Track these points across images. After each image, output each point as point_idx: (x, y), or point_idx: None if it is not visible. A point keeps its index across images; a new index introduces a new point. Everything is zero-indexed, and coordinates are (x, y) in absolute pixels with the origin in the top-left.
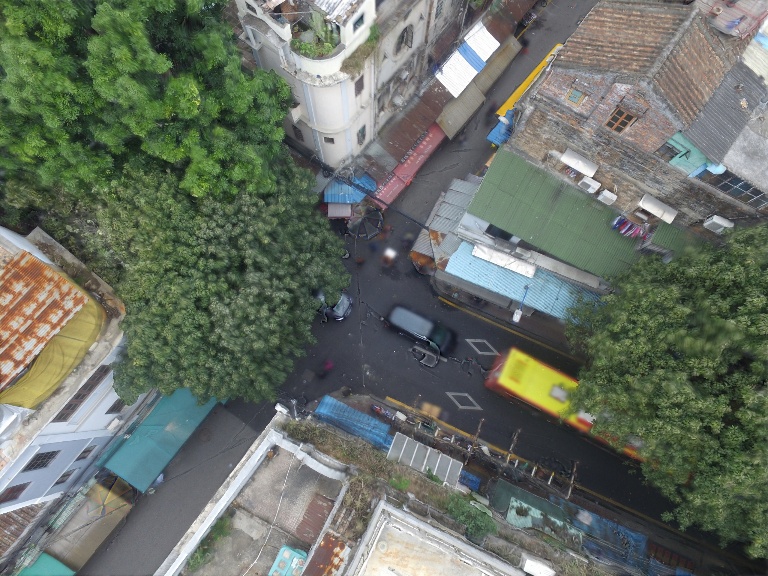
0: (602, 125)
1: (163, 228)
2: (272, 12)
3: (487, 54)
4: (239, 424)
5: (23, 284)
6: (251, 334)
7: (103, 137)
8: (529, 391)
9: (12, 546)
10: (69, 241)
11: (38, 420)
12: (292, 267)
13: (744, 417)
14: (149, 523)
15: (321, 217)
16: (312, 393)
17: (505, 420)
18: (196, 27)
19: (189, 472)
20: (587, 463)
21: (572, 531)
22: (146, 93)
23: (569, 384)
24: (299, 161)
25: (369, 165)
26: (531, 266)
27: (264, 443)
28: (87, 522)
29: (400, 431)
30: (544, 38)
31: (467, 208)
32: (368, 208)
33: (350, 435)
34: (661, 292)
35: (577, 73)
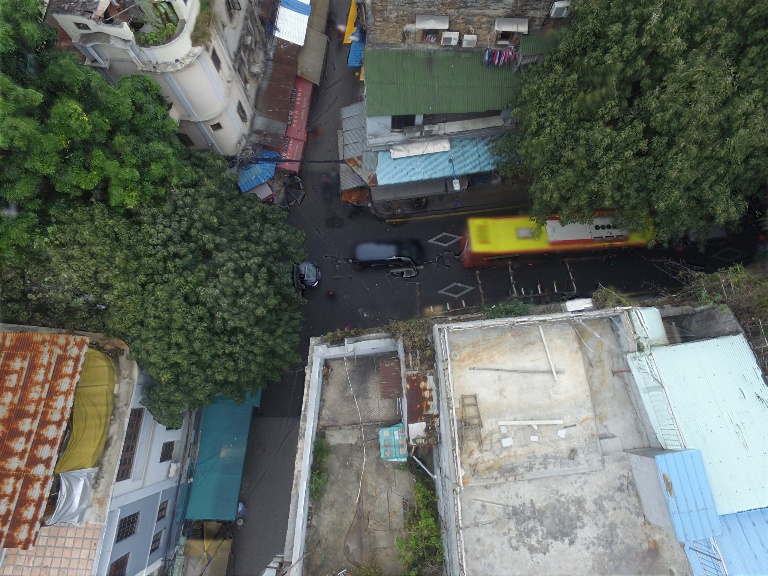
0: None
1: None
2: (103, 19)
3: None
4: (282, 422)
5: (20, 360)
6: (249, 304)
7: (17, 191)
8: (501, 245)
9: None
10: (36, 318)
11: (105, 477)
12: (249, 242)
13: (657, 123)
14: (255, 550)
15: None
16: None
17: (497, 285)
18: (41, 69)
19: (263, 487)
20: (578, 279)
21: None
22: (34, 128)
23: (528, 221)
24: None
25: None
26: (444, 141)
27: (315, 361)
28: (199, 574)
29: None
30: None
31: (366, 114)
32: (283, 178)
33: None
34: (549, 77)
35: None
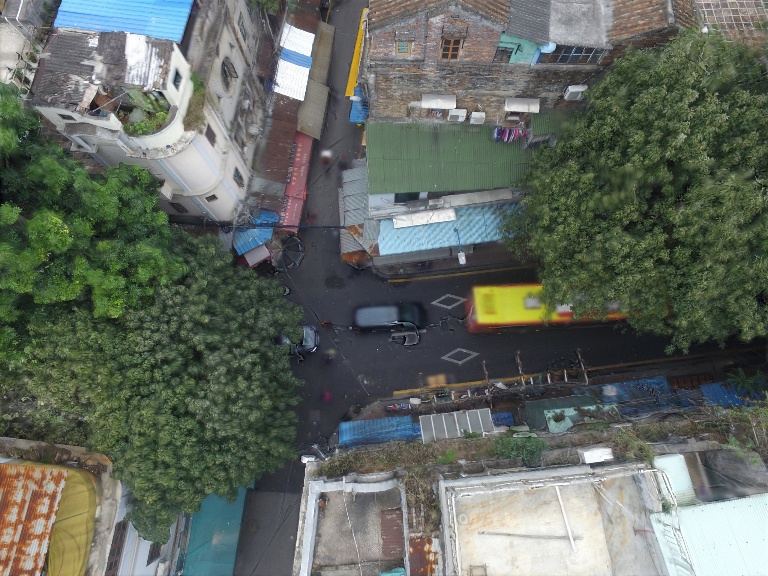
0: (439, 60)
1: (101, 364)
2: (89, 111)
3: (308, 49)
4: (278, 497)
5: None
6: (242, 410)
7: None
8: (508, 315)
9: None
10: (14, 429)
11: None
12: (244, 329)
13: (680, 235)
14: None
15: (244, 270)
16: (327, 429)
17: (502, 351)
18: (22, 162)
19: (257, 568)
20: (587, 346)
21: (606, 408)
22: (9, 249)
23: (536, 290)
24: (194, 232)
25: (260, 201)
26: (449, 210)
27: (310, 498)
28: None
29: (422, 414)
30: (349, 10)
31: (368, 191)
32: (282, 239)
33: (381, 444)
34: (563, 172)
35: (393, 27)
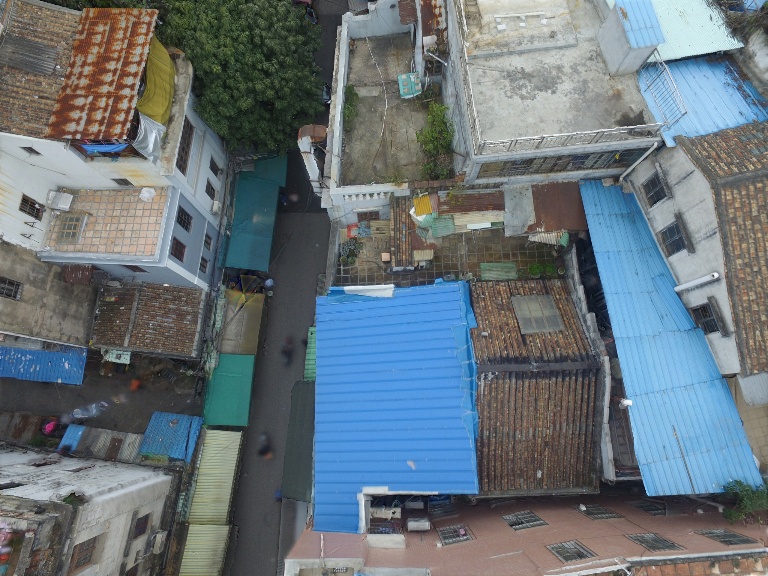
0: None
1: None
2: None
3: None
4: (304, 216)
5: (102, 25)
6: (282, 31)
7: None
8: None
9: (196, 339)
10: None
11: (171, 143)
12: None
13: None
14: (284, 318)
15: None
16: None
17: None
18: None
19: (289, 268)
20: None
21: None
22: None
23: None
24: None
25: None
26: None
27: (343, 25)
28: None
29: None
30: None
31: None
32: None
33: None
34: None
35: None
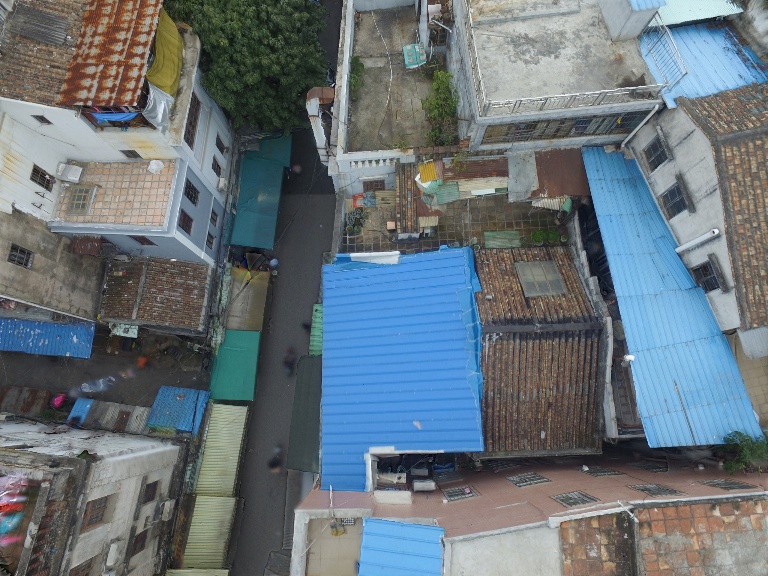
0: None
1: None
2: None
3: None
4: (308, 197)
5: None
6: (287, 7)
7: None
8: None
9: (203, 313)
10: None
11: (179, 114)
12: None
13: None
14: (288, 297)
15: None
16: None
17: None
18: None
19: (294, 249)
20: None
21: None
22: None
23: None
24: None
25: None
26: None
27: None
28: None
29: None
30: None
31: None
32: None
33: None
34: None
35: None
